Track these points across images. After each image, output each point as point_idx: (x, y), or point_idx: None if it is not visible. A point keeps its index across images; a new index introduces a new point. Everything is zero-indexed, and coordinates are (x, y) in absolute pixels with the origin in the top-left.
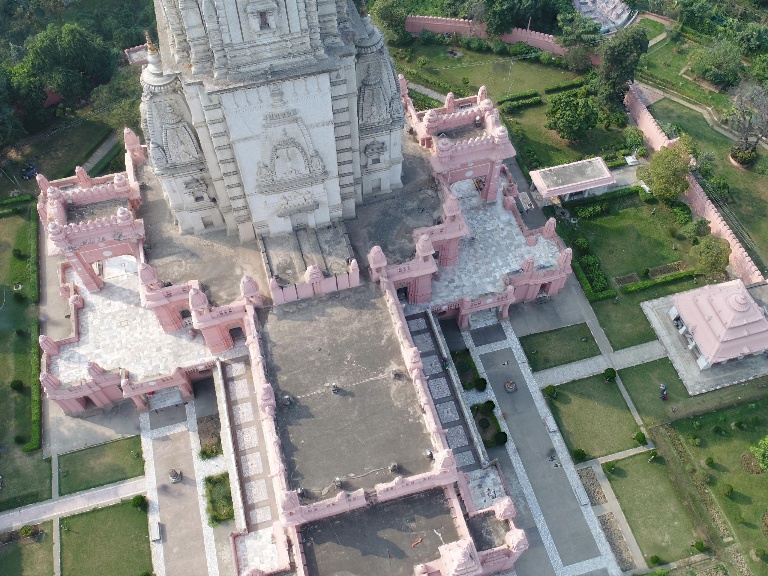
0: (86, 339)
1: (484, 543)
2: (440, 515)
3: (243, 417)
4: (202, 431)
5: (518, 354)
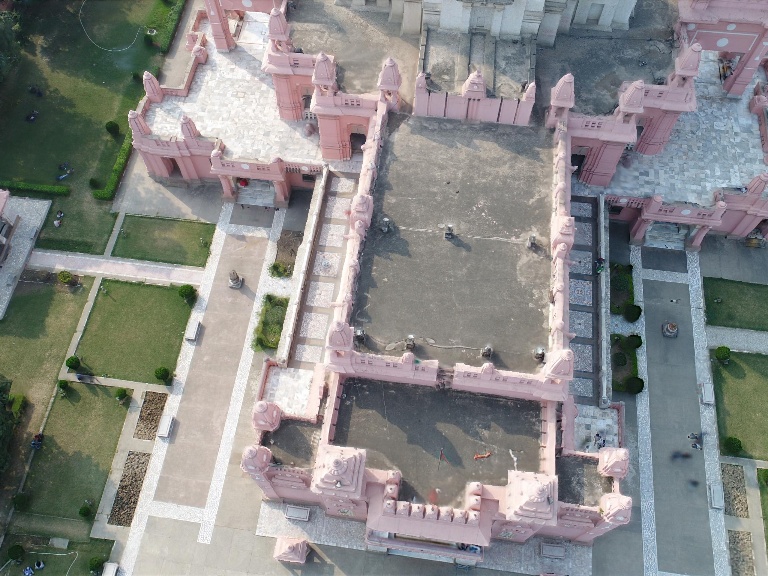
0: (195, 97)
1: (569, 493)
2: (525, 435)
3: (331, 239)
4: (282, 242)
5: (695, 295)
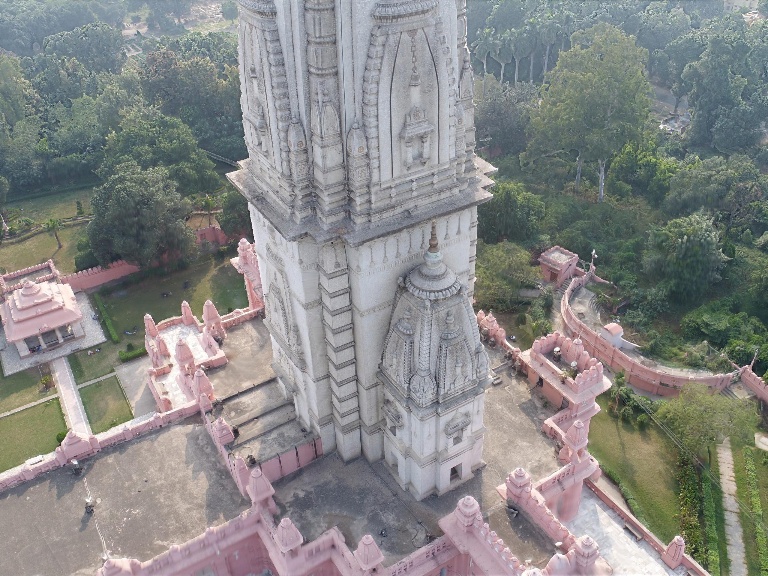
0: None
1: None
2: None
3: None
4: None
5: None
